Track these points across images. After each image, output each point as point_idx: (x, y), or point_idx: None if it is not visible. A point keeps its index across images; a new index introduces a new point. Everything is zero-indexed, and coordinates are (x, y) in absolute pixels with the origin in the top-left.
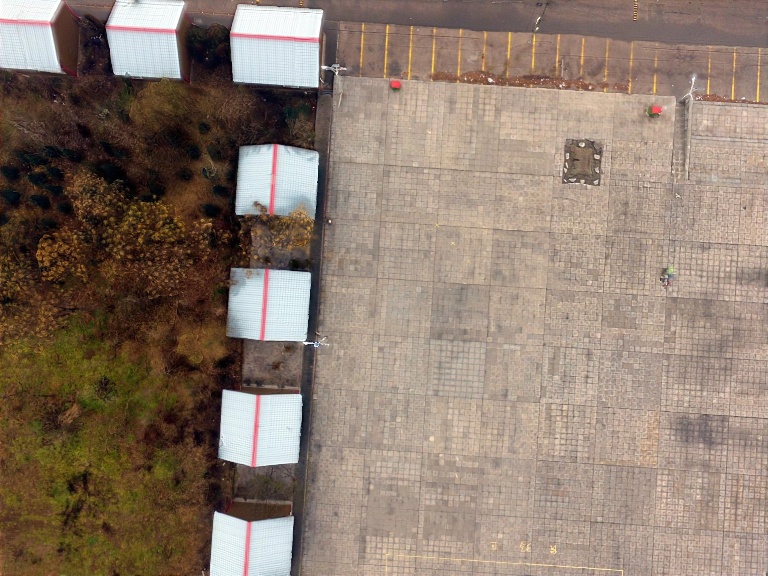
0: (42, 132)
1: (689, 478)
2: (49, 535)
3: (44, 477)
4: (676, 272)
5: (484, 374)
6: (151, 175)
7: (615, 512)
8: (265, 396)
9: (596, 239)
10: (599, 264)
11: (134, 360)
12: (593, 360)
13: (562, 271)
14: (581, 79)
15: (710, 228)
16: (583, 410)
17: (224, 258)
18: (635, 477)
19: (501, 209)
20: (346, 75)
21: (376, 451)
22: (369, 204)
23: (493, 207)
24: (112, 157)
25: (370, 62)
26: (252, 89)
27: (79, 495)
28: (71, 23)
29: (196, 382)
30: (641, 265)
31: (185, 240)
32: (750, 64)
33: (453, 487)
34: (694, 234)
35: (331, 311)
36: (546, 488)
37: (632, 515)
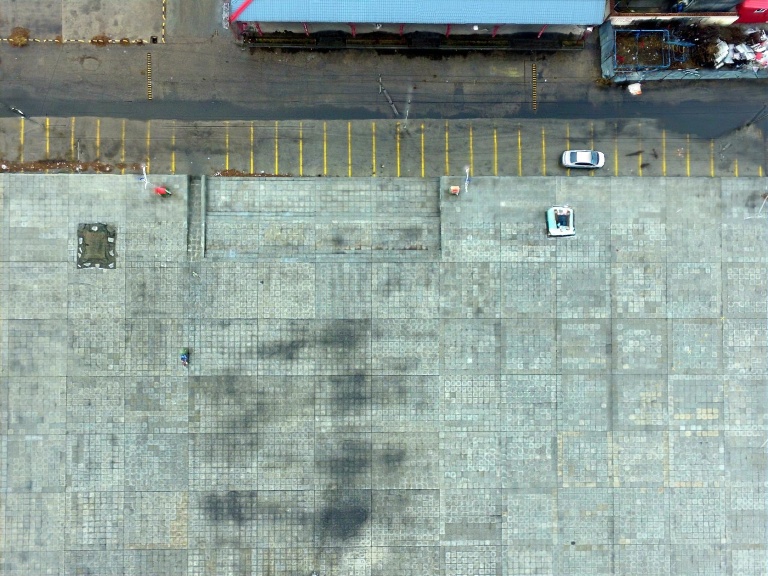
0: None
1: (220, 556)
2: None
3: None
4: (197, 350)
5: (6, 467)
6: None
7: None
8: None
9: (115, 323)
10: (119, 348)
11: None
12: (118, 445)
13: (82, 357)
14: (98, 161)
15: (229, 304)
16: (110, 496)
17: None
18: (166, 559)
19: (16, 298)
20: None
21: None
22: None
23: (7, 297)
24: None
25: None
26: None
27: None
28: None
29: None
30: (162, 346)
31: None
32: (267, 137)
33: None
34: (213, 311)
35: None
36: None
37: None
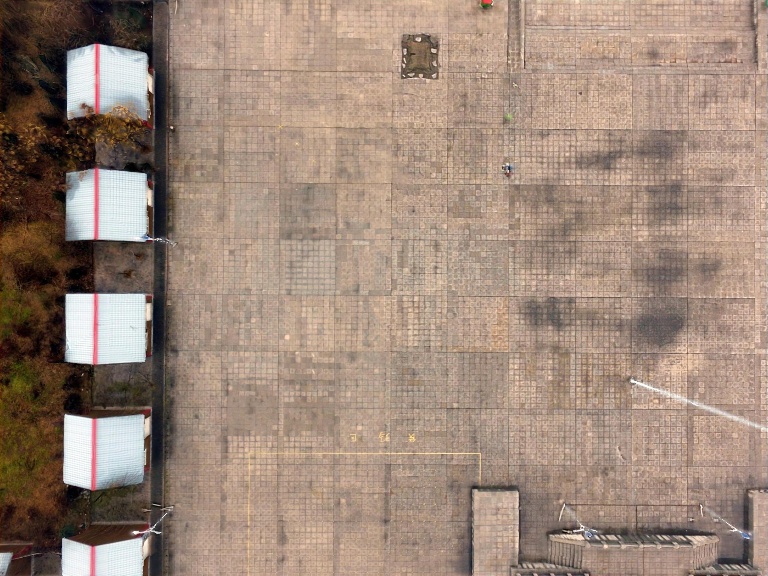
0: None
1: (540, 360)
2: None
3: None
4: (517, 160)
5: (335, 271)
6: None
7: (470, 397)
8: (103, 295)
9: (438, 132)
10: (442, 156)
11: None
12: (441, 251)
13: (406, 165)
14: None
15: (548, 115)
16: (434, 300)
17: (60, 165)
18: (488, 362)
19: (343, 107)
20: None
21: (233, 353)
22: (211, 109)
23: (335, 106)
24: None
25: None
26: None
27: None
28: None
29: (49, 295)
30: (483, 155)
31: (11, 143)
32: None
33: (310, 383)
34: (533, 122)
35: (180, 217)
36: (402, 378)
37: (487, 399)
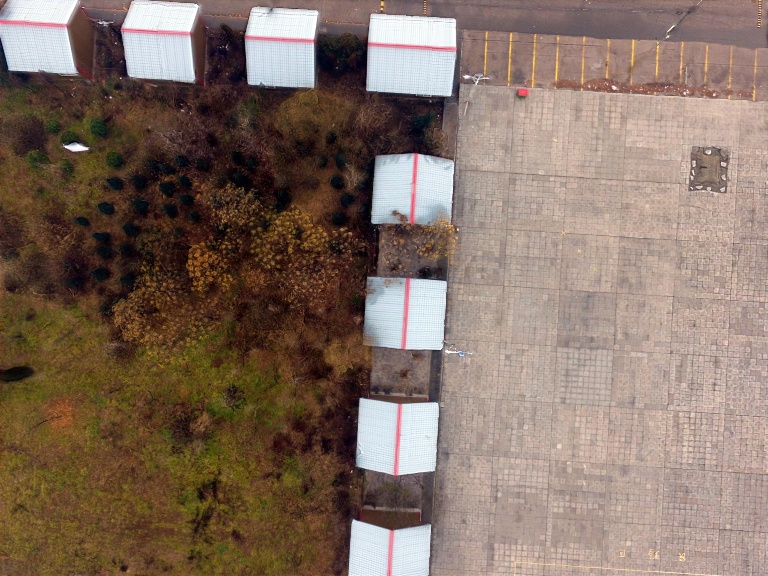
0: (180, 142)
1: None
2: (180, 543)
3: (174, 485)
4: None
5: (611, 382)
6: (279, 184)
7: (744, 520)
8: (406, 405)
9: (723, 246)
10: (726, 271)
11: (262, 368)
12: (721, 367)
13: (689, 279)
14: (705, 86)
15: None
16: (711, 418)
17: (359, 267)
18: (764, 485)
19: (627, 217)
20: (470, 83)
21: (504, 459)
22: (495, 212)
23: (619, 215)
24: (239, 166)
25: (494, 70)
26: (383, 98)
27: (209, 503)
28: (201, 33)
29: (323, 390)
30: None
31: (328, 249)
32: None
33: (581, 495)
34: None
35: (458, 319)
36: (674, 496)
37: (761, 523)
